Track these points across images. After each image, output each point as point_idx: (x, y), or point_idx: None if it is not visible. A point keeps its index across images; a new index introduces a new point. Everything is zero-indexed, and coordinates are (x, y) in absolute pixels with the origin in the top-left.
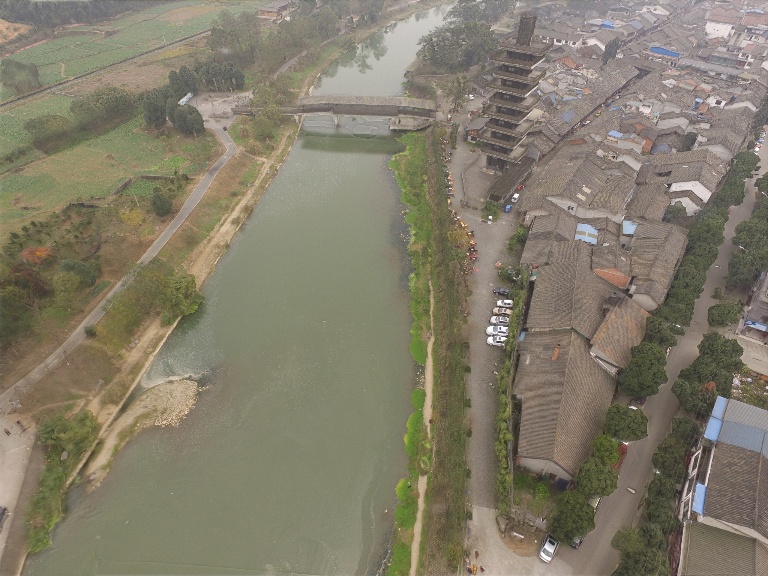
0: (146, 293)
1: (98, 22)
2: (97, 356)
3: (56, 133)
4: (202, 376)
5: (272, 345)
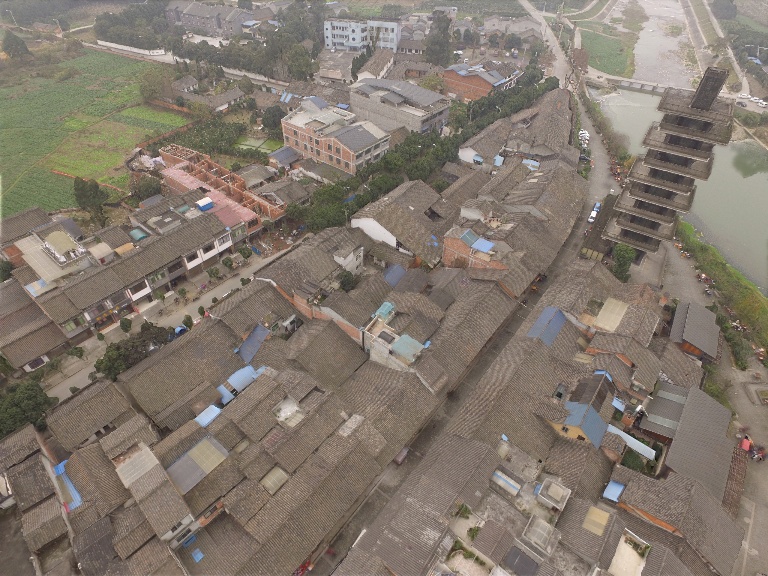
0: None
1: None
2: None
3: None
4: None
5: None
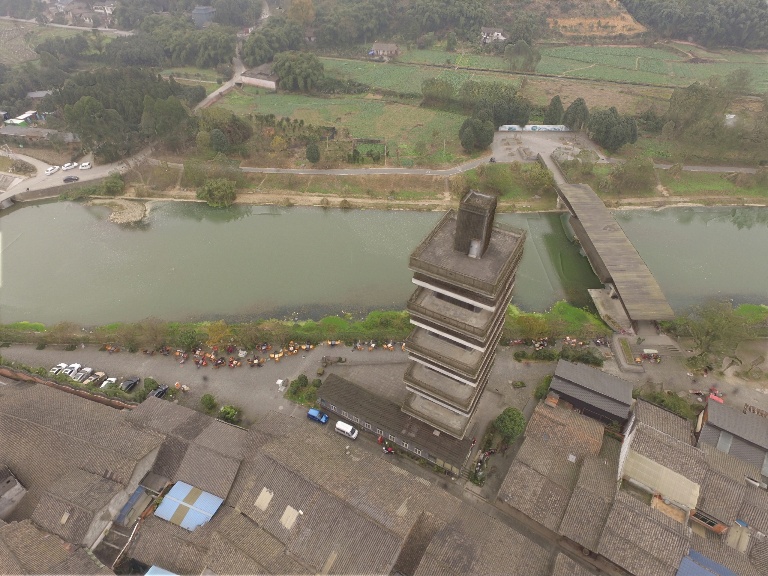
0: (195, 169)
1: (725, 49)
2: (173, 178)
3: (432, 95)
4: (144, 221)
5: (159, 246)
